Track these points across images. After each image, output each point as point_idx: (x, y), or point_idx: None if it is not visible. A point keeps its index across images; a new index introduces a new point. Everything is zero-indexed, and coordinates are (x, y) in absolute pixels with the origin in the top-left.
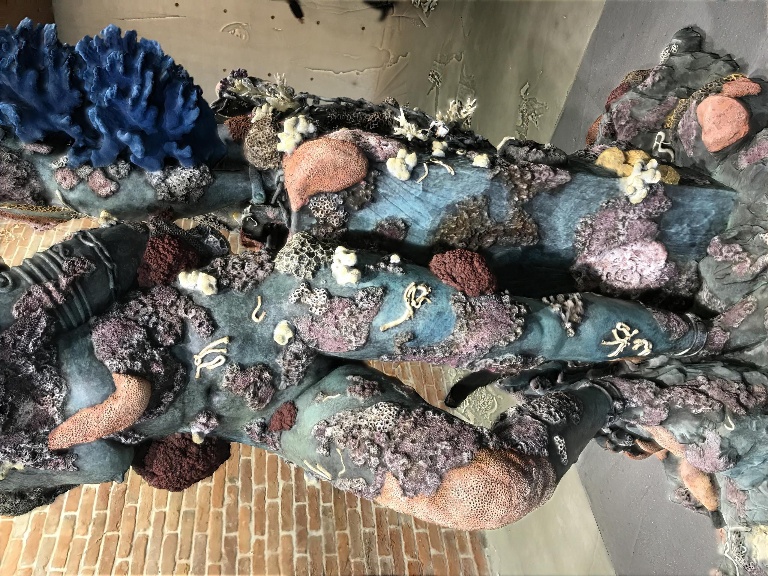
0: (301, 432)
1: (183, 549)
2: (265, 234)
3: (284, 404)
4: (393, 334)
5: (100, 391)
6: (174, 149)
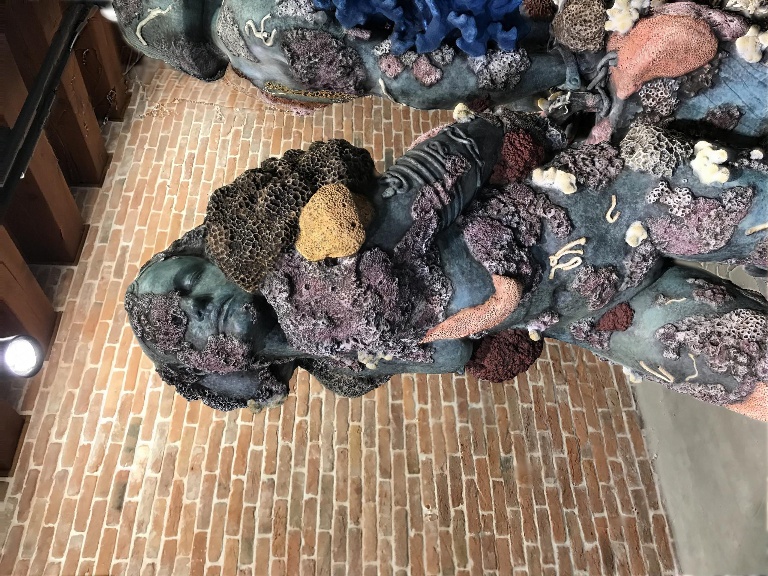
0: (640, 334)
1: (354, 412)
2: (567, 122)
3: (619, 305)
4: (758, 238)
5: (482, 292)
6: (499, 31)
